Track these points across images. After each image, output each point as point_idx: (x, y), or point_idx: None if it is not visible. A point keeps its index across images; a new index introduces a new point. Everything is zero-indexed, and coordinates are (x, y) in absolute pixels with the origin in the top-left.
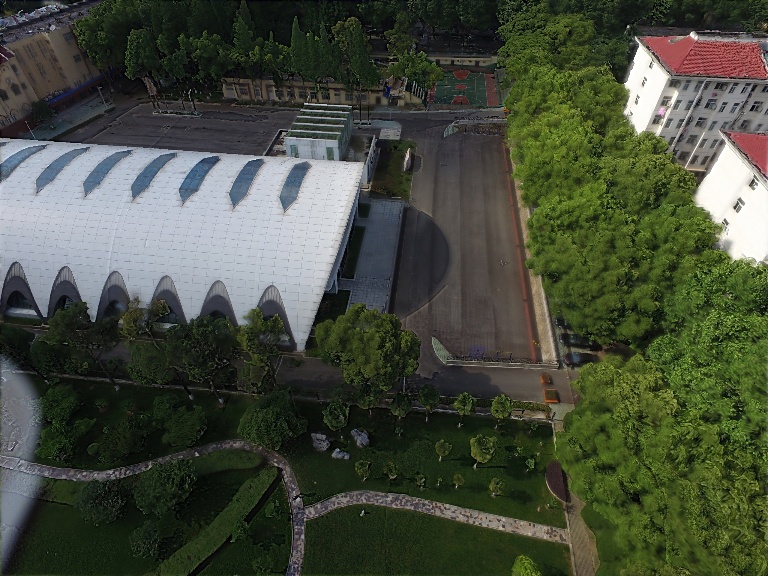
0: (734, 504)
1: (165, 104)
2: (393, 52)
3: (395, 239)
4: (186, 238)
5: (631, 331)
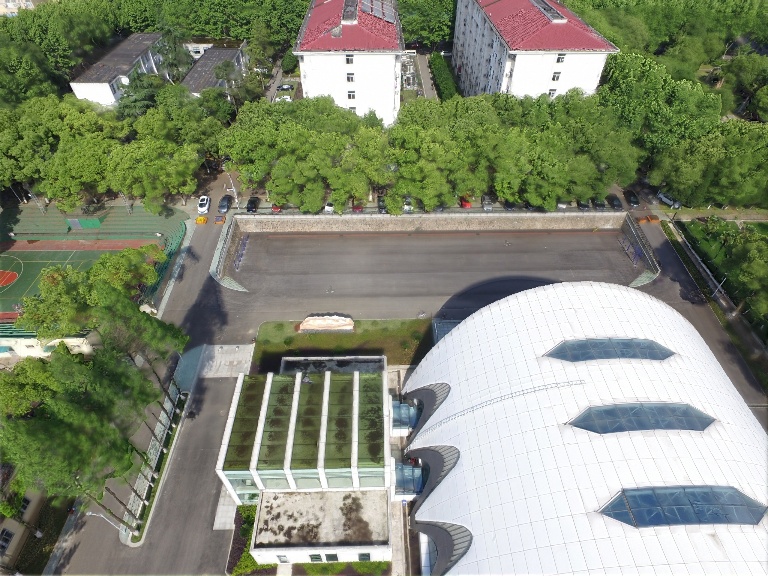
0: (763, 127)
1: None
2: None
3: None
4: None
5: (640, 153)
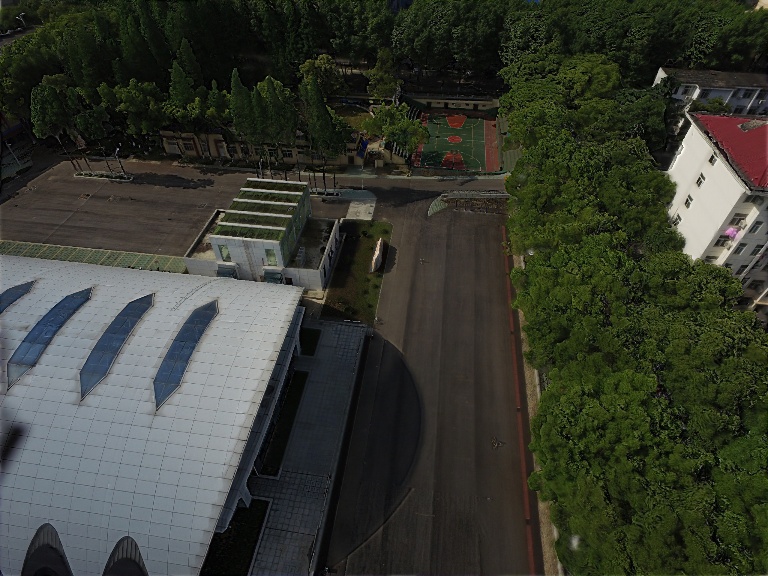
0: None
1: (88, 165)
2: (374, 95)
3: (346, 396)
4: (3, 451)
5: None
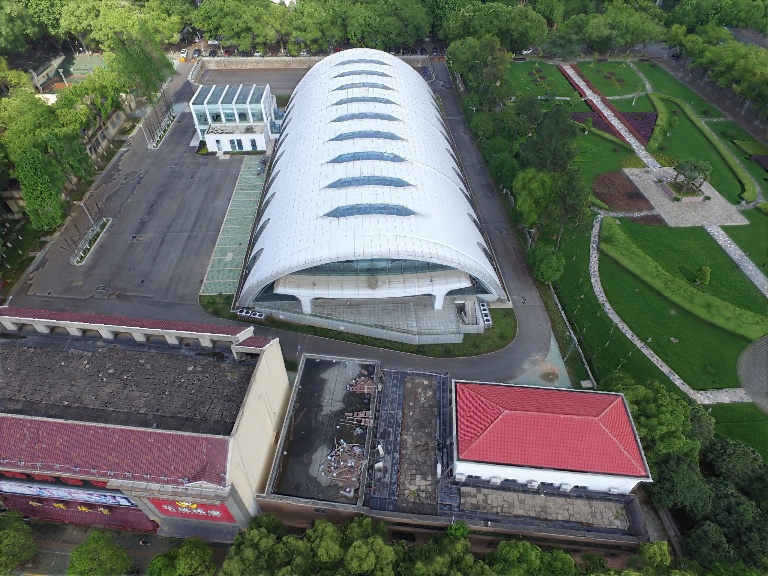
0: (496, 3)
1: None
2: None
3: None
4: None
5: None
